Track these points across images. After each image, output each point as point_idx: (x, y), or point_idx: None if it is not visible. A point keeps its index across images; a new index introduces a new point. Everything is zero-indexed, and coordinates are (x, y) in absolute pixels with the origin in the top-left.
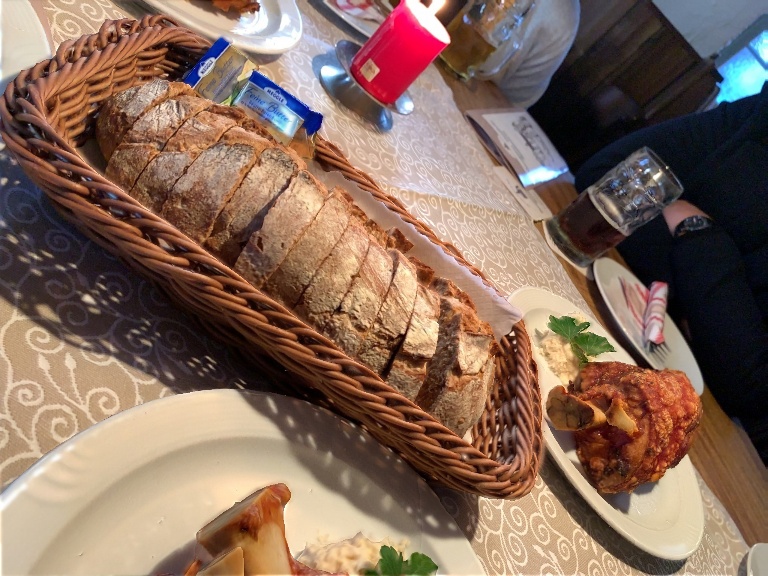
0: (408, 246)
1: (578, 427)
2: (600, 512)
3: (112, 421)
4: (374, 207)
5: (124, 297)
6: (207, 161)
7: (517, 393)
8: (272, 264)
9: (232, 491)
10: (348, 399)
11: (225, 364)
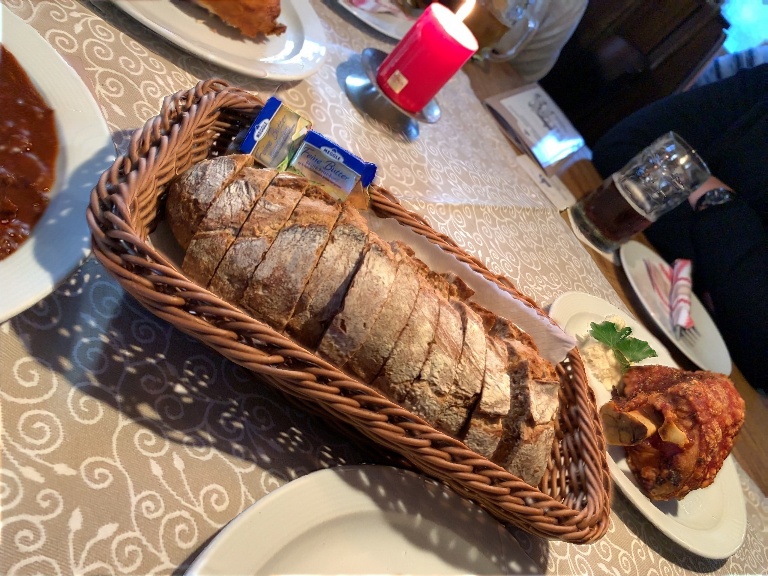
0: (470, 294)
1: (631, 443)
2: (656, 524)
3: (233, 527)
4: (429, 249)
5: (210, 379)
6: (283, 245)
7: (580, 427)
8: (356, 344)
9: (339, 569)
10: (439, 472)
11: (309, 432)
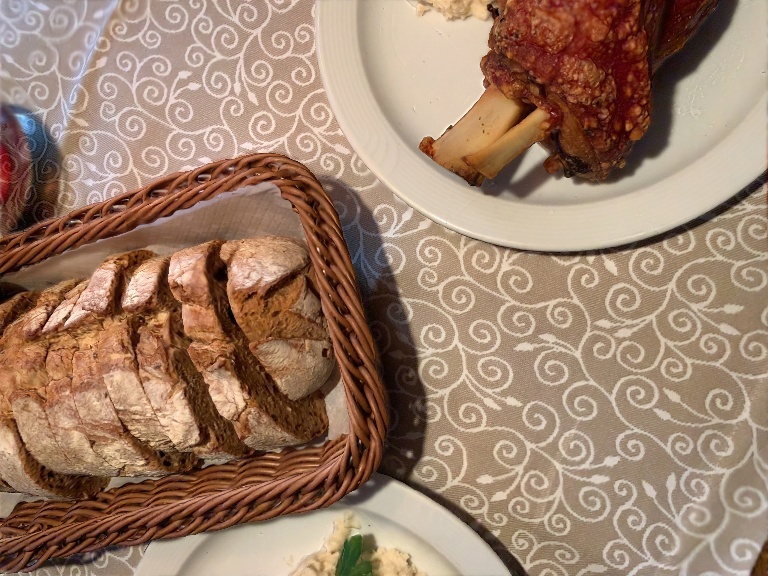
0: None
1: None
2: (577, 250)
3: None
4: (70, 254)
5: None
6: None
7: None
8: None
9: None
10: None
11: None
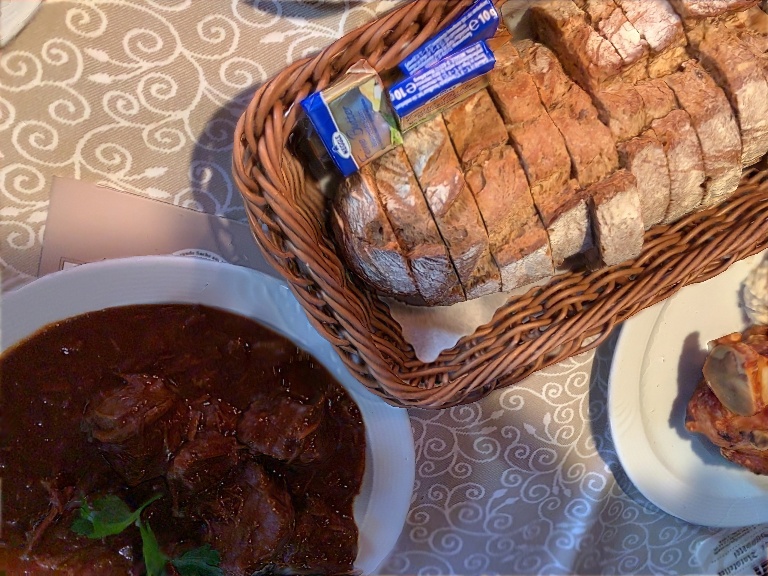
0: None
1: None
2: None
3: (613, 379)
4: None
5: None
6: (511, 271)
7: None
8: None
9: (682, 308)
10: None
11: None
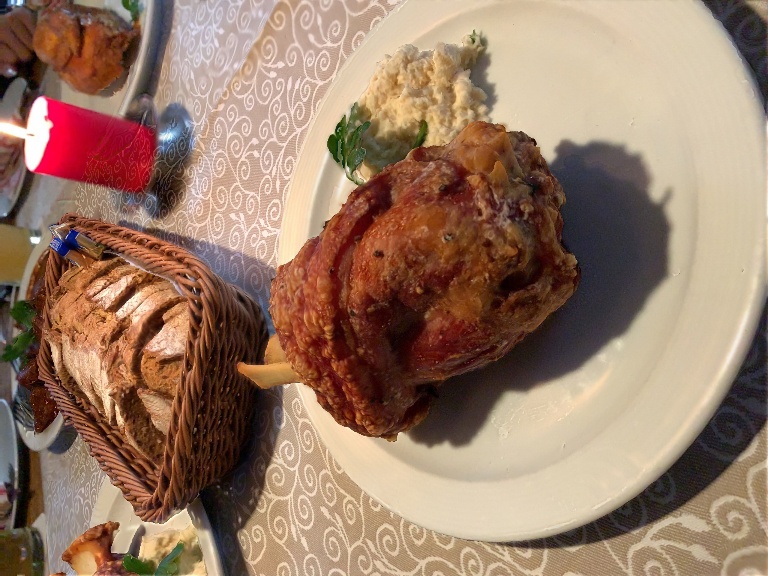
0: None
1: None
2: None
3: None
4: None
5: None
6: None
7: None
8: None
9: None
10: None
11: None
